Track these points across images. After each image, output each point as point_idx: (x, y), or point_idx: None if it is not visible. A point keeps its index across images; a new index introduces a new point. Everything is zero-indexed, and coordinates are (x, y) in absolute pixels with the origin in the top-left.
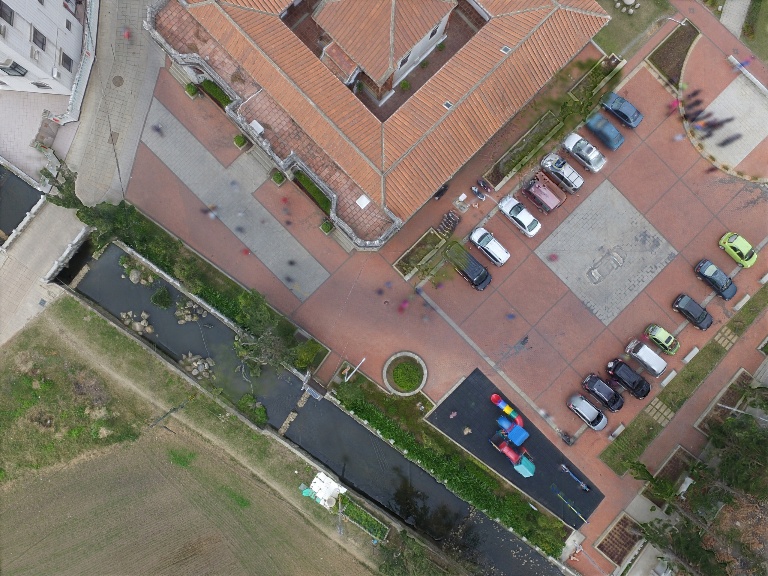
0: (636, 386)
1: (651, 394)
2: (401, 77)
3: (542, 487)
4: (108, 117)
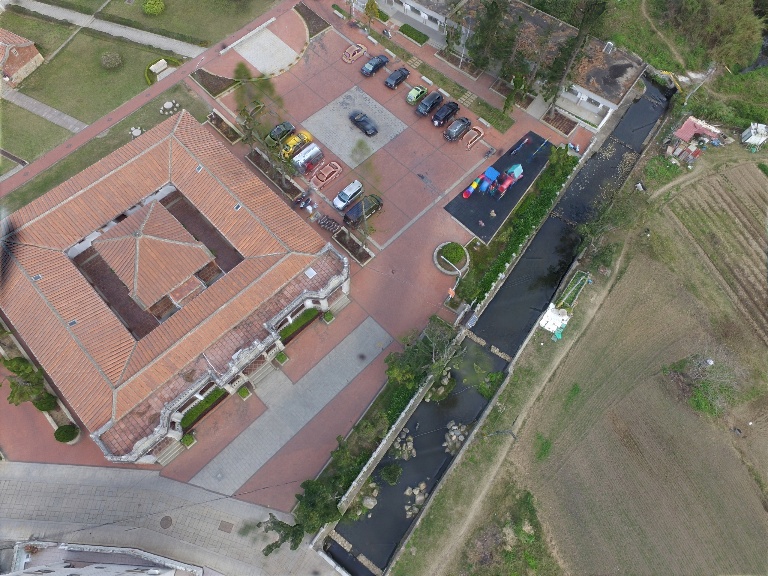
0: (450, 109)
1: None
2: None
3: (529, 168)
4: None
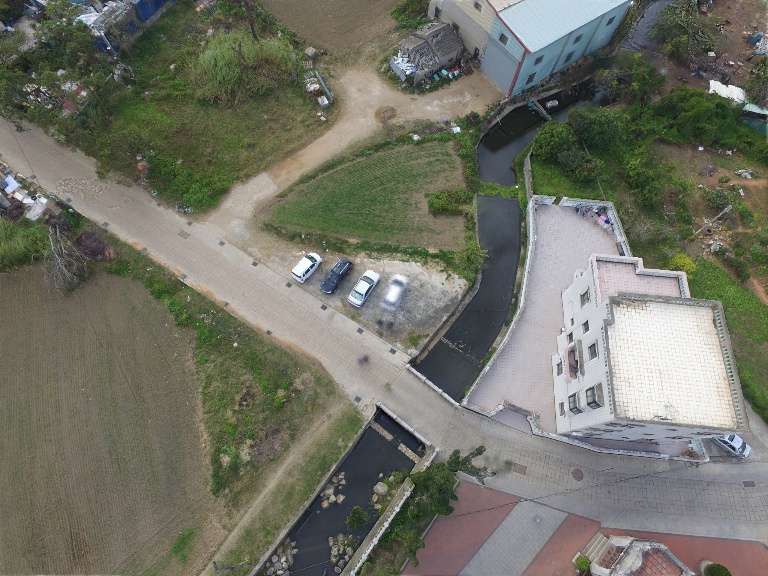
0: None
1: None
2: None
3: None
4: None
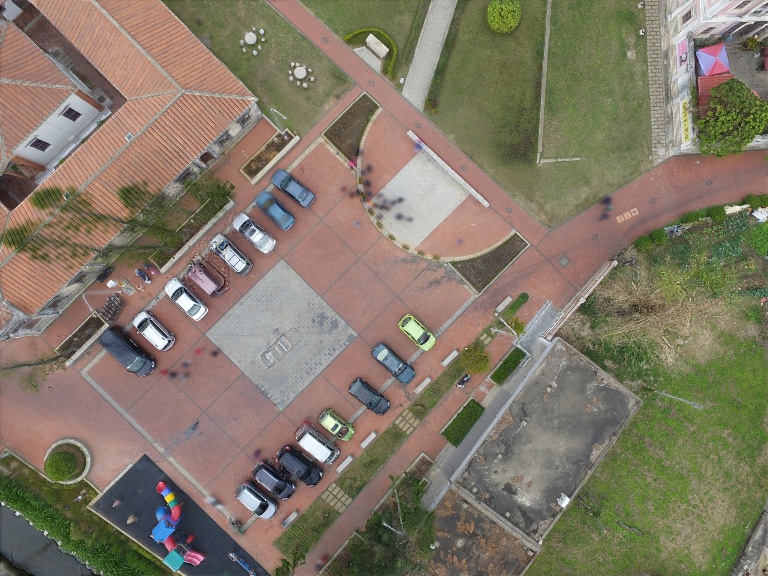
0: (302, 474)
1: (328, 480)
2: (61, 155)
3: (213, 575)
4: None
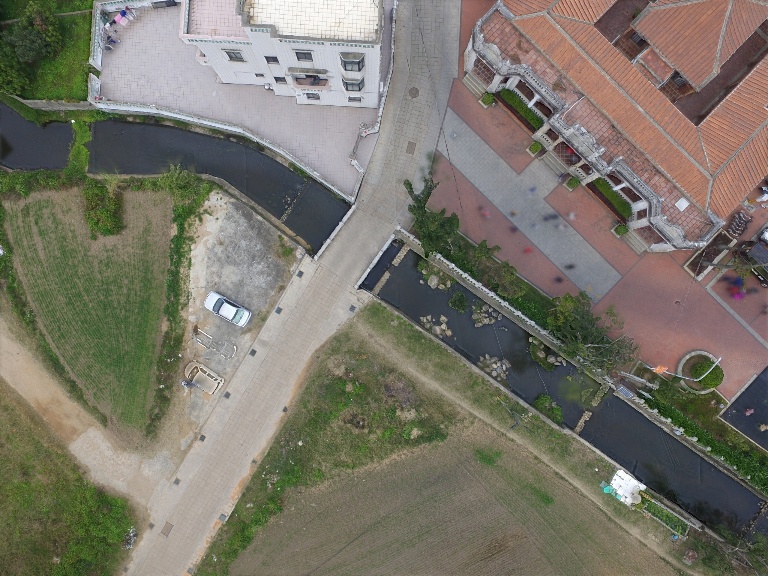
0: None
1: None
2: None
3: None
4: (442, 128)
